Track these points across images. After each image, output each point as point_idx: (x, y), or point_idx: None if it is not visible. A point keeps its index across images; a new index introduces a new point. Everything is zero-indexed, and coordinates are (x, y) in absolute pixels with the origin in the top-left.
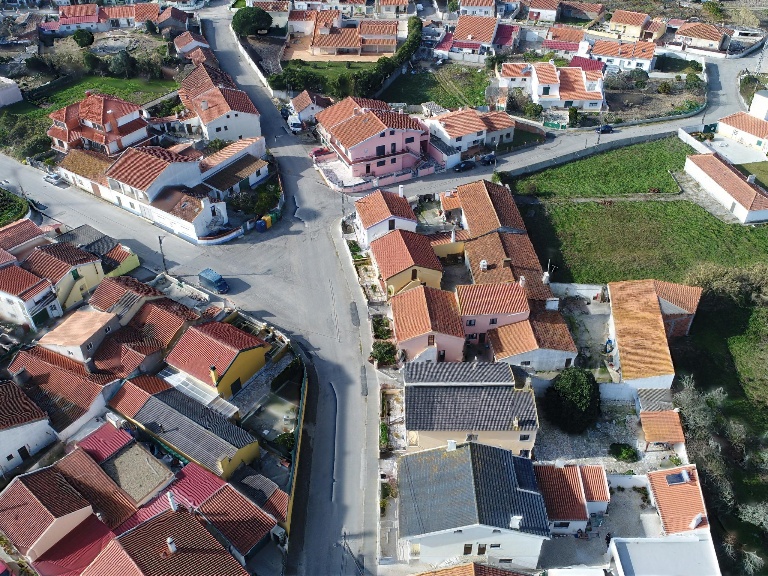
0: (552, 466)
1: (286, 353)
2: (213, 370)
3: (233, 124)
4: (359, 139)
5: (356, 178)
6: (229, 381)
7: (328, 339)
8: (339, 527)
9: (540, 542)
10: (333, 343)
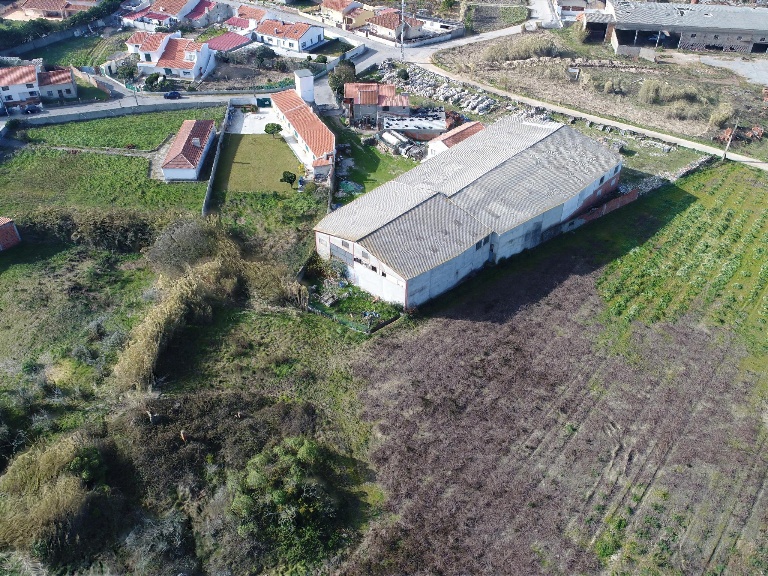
0: None
1: None
2: None
3: None
4: None
5: None
6: None
7: None
8: None
9: None
10: None
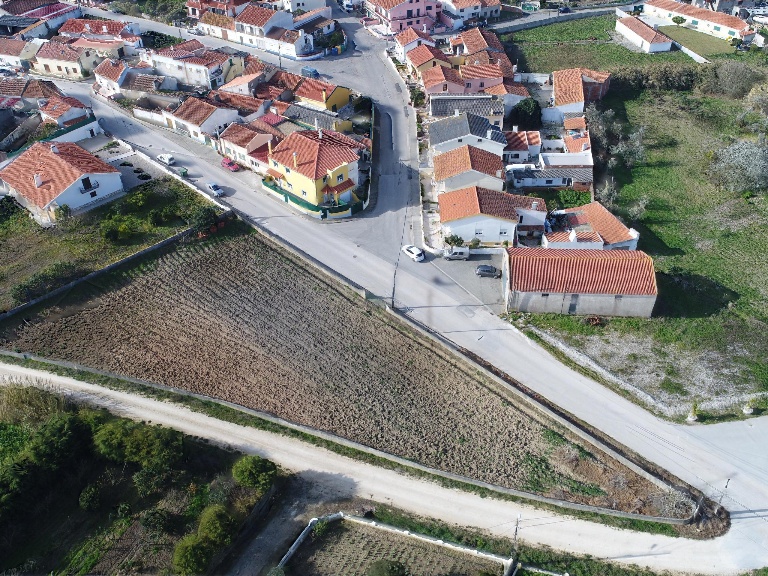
0: (511, 132)
1: (360, 101)
2: (325, 91)
3: (308, 1)
4: (396, 4)
5: (393, 32)
6: (332, 103)
7: (384, 97)
8: (398, 157)
9: (502, 150)
10: (387, 98)
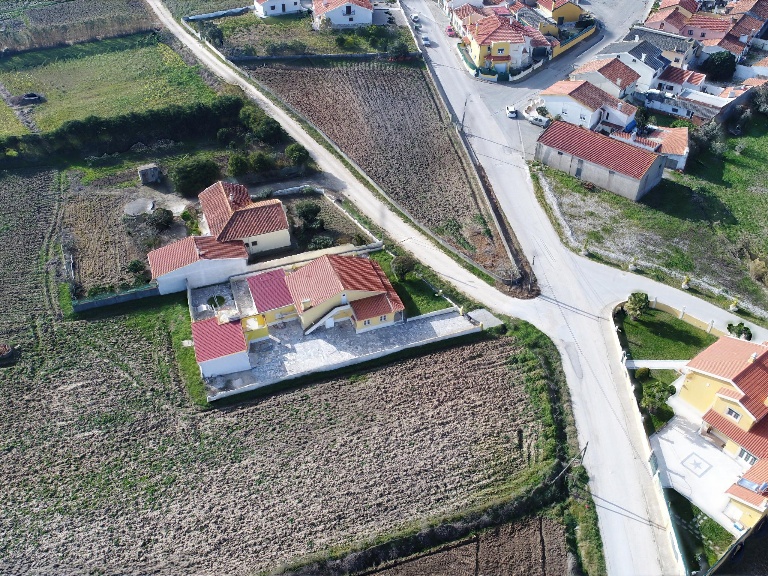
0: (681, 68)
1: None
2: (554, 2)
3: None
4: None
5: None
6: (559, 14)
7: (615, 26)
8: (574, 62)
9: (651, 74)
10: (616, 27)
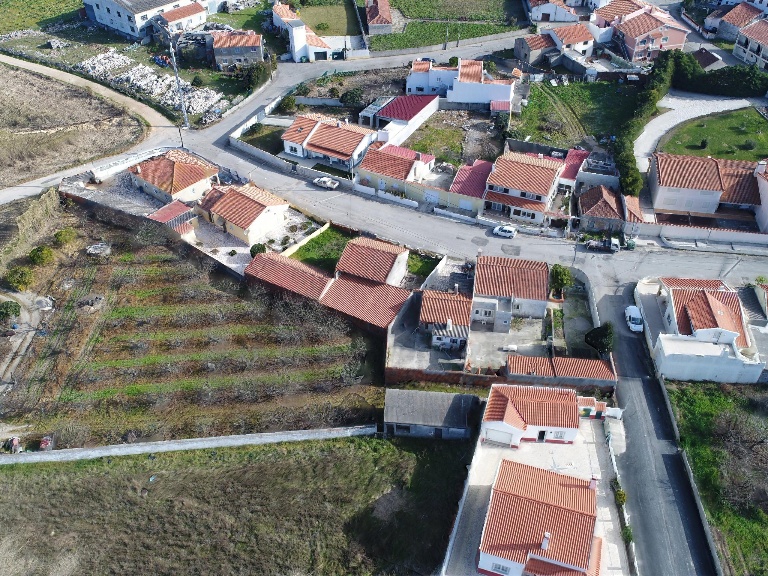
0: None
1: None
2: None
3: None
4: None
5: None
6: None
7: None
8: None
9: None
10: None
